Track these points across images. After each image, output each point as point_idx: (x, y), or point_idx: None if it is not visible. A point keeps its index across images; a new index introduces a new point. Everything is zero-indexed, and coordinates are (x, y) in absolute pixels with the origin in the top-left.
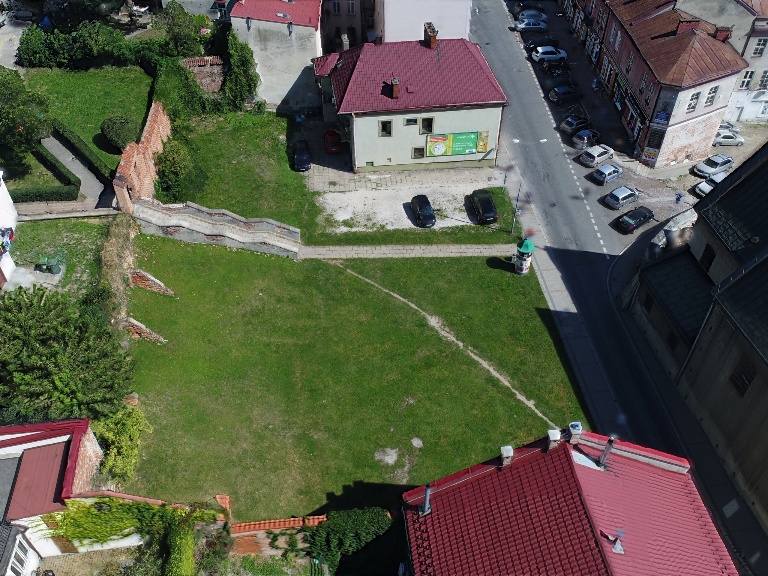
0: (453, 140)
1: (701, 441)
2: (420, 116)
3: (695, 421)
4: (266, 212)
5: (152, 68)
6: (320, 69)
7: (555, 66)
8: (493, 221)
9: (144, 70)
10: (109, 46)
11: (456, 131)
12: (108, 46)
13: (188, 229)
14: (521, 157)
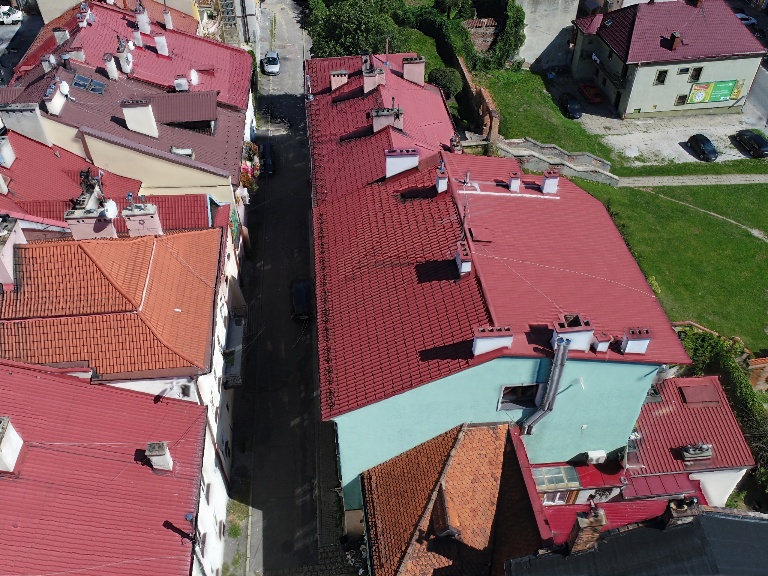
0: (713, 88)
1: None
2: (693, 66)
3: None
4: (571, 150)
5: (434, 30)
6: (588, 28)
7: (753, 30)
8: (767, 155)
9: (423, 32)
10: (400, 10)
11: (718, 80)
12: (399, 10)
13: (538, 158)
14: (759, 105)
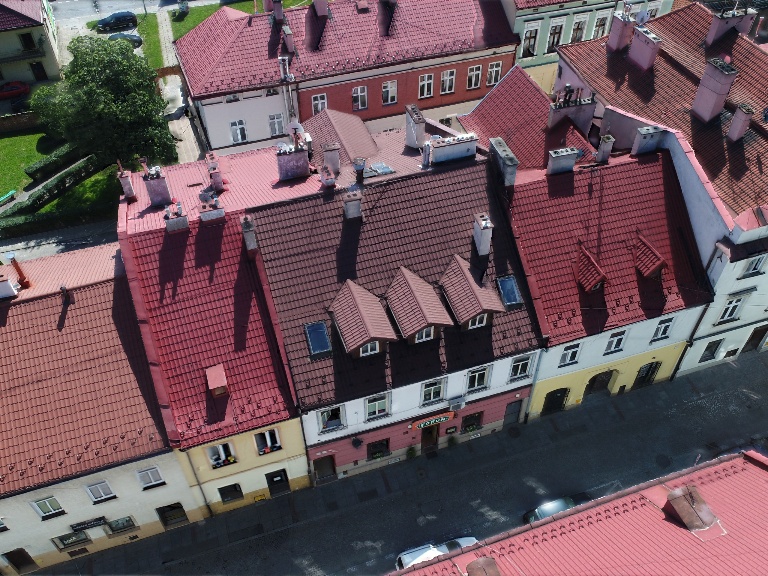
0: None
1: None
2: None
3: None
4: None
5: None
6: None
7: None
8: None
9: None
10: None
11: (46, 6)
12: None
13: None
14: None
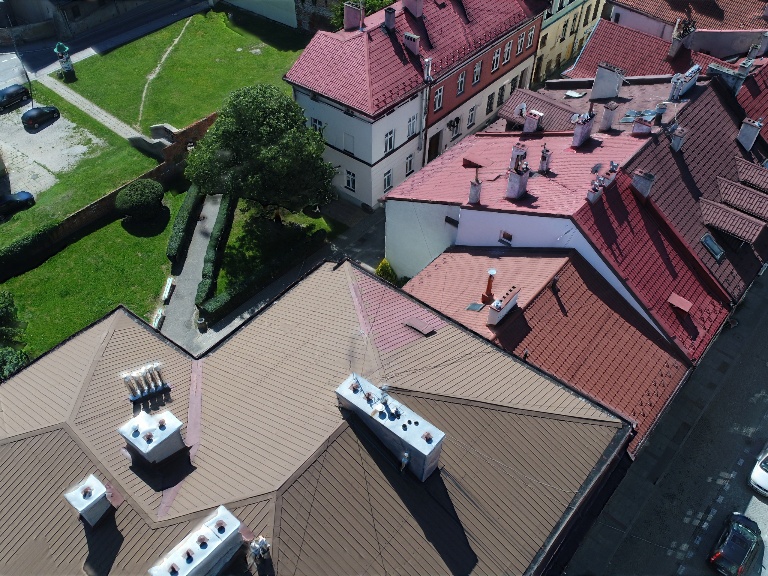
0: None
1: (149, 5)
2: None
3: (138, 8)
4: None
5: None
6: None
7: None
8: None
9: None
10: None
11: None
12: None
13: None
14: None
